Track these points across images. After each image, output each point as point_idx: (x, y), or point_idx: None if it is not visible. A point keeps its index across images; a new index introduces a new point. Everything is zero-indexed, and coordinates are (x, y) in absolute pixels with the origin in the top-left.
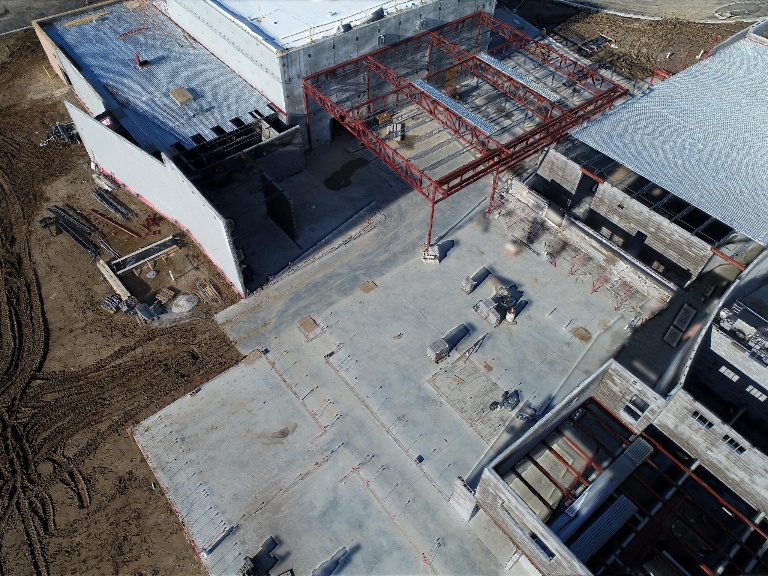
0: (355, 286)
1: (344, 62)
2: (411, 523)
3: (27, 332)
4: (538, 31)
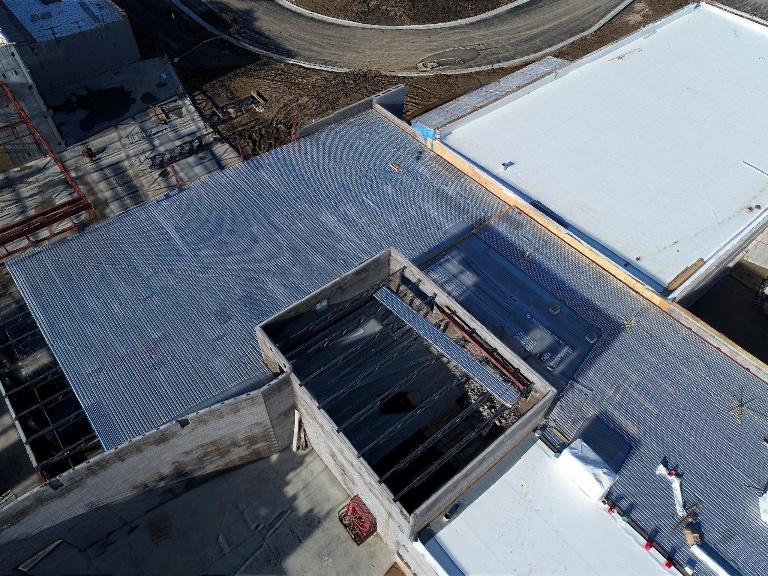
0: None
1: None
2: None
3: None
4: None
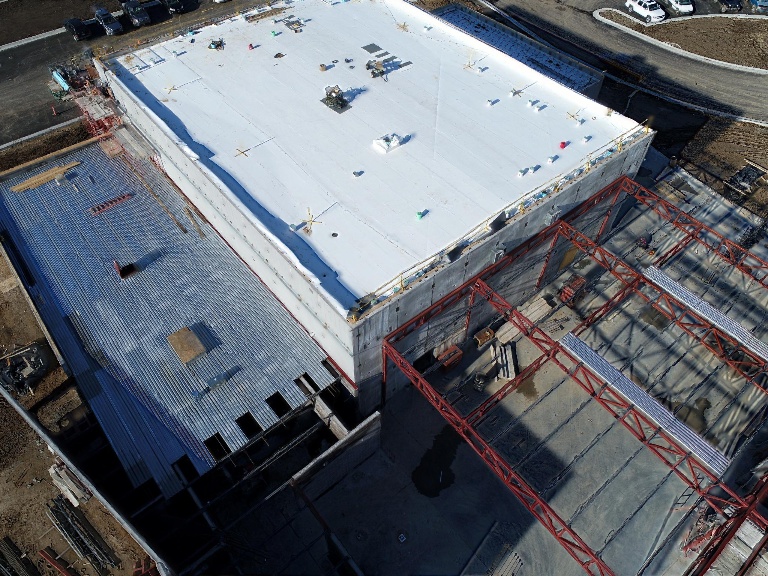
0: None
1: (444, 296)
2: None
3: None
4: (663, 157)
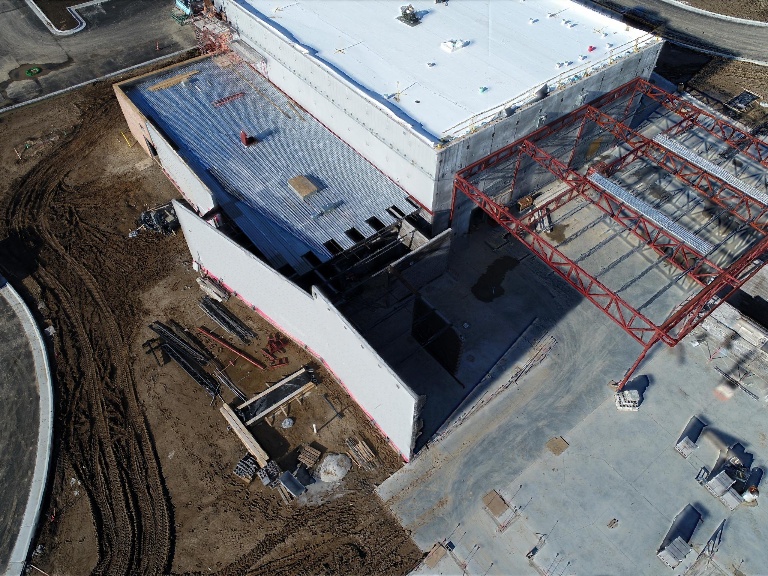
0: (541, 444)
1: (500, 149)
2: None
3: (146, 509)
4: (672, 85)
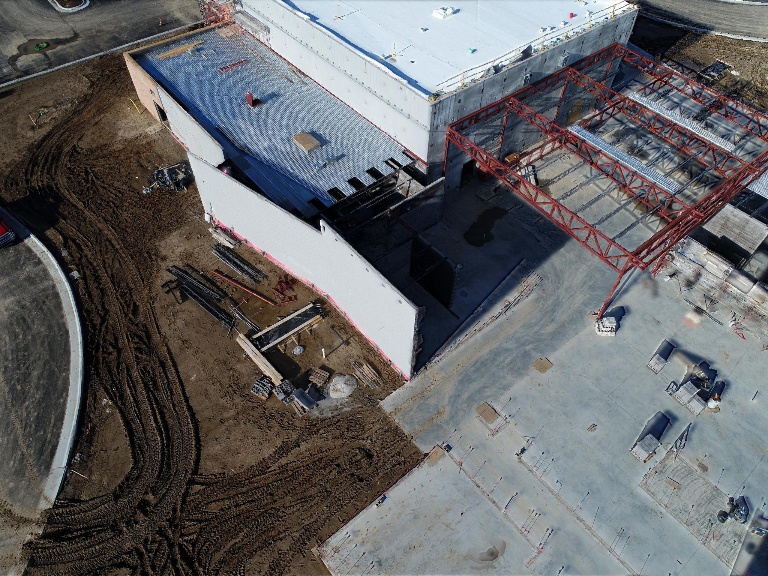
0: (528, 364)
1: (488, 105)
2: None
3: (172, 423)
4: (650, 56)
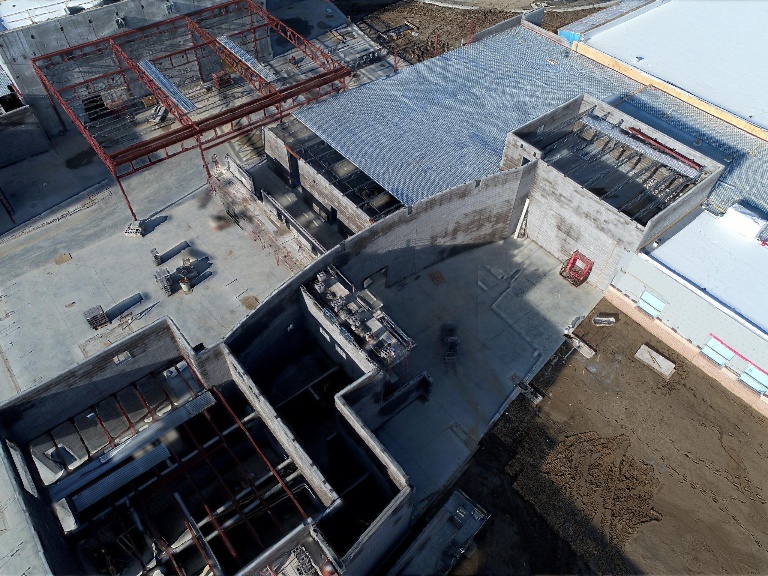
0: (50, 258)
1: (81, 44)
2: (1, 475)
3: None
4: None
